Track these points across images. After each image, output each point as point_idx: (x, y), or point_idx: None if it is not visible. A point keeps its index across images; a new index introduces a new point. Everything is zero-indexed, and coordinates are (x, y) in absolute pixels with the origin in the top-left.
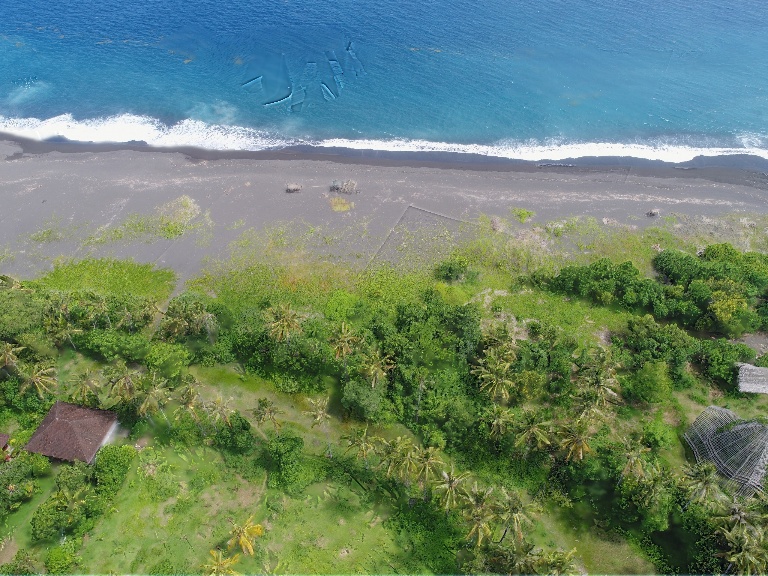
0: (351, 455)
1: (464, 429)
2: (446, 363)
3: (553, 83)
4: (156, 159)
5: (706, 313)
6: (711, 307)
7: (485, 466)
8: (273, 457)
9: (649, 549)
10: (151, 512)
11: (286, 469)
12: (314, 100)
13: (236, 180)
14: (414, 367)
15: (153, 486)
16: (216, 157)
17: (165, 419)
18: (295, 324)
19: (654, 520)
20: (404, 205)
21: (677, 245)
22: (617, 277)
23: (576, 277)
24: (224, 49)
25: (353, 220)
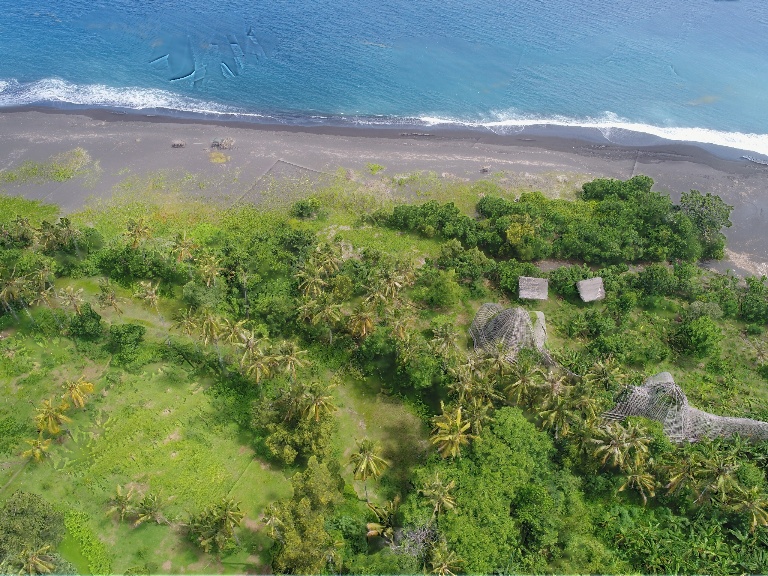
0: (188, 343)
1: (283, 320)
2: (280, 274)
3: (427, 69)
4: (59, 119)
5: (507, 242)
6: (507, 234)
7: (298, 350)
8: (115, 338)
9: (419, 408)
10: (4, 384)
11: (125, 348)
12: (213, 76)
13: (128, 137)
14: (248, 274)
15: (9, 364)
16: (115, 119)
17: (29, 316)
18: (147, 235)
19: (415, 377)
20: (274, 159)
21: (500, 194)
22: (440, 214)
23: (405, 213)
24: (134, 29)
25: (227, 170)
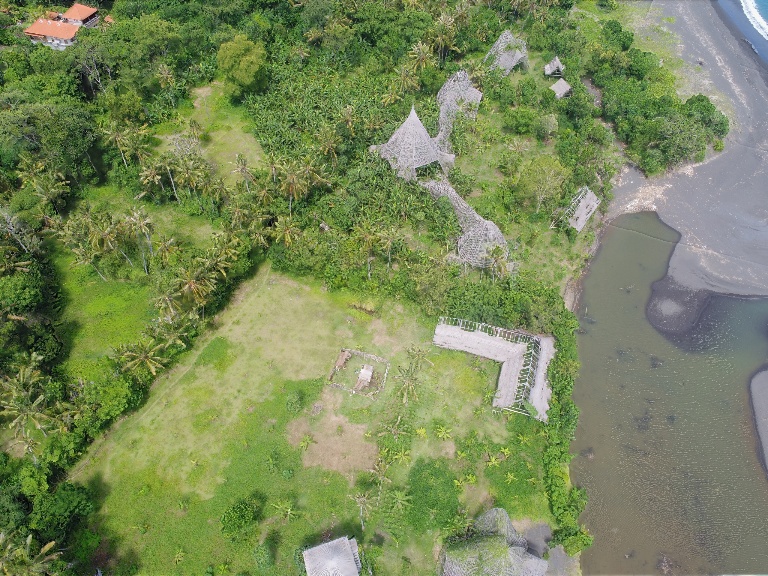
0: None
1: None
2: None
3: None
4: None
5: None
6: None
7: (483, 8)
8: None
9: None
10: None
11: None
12: None
13: None
14: None
15: None
16: None
17: None
18: None
19: None
20: None
21: (669, 68)
22: None
23: None
24: None
25: None
